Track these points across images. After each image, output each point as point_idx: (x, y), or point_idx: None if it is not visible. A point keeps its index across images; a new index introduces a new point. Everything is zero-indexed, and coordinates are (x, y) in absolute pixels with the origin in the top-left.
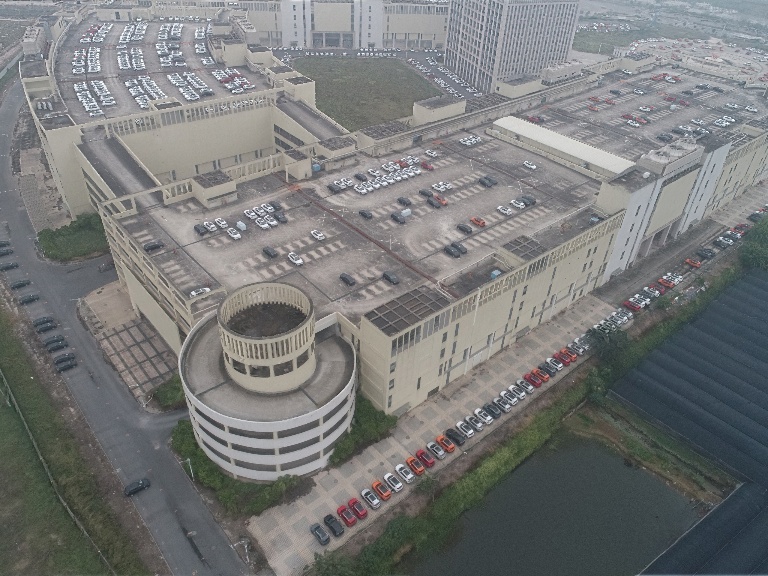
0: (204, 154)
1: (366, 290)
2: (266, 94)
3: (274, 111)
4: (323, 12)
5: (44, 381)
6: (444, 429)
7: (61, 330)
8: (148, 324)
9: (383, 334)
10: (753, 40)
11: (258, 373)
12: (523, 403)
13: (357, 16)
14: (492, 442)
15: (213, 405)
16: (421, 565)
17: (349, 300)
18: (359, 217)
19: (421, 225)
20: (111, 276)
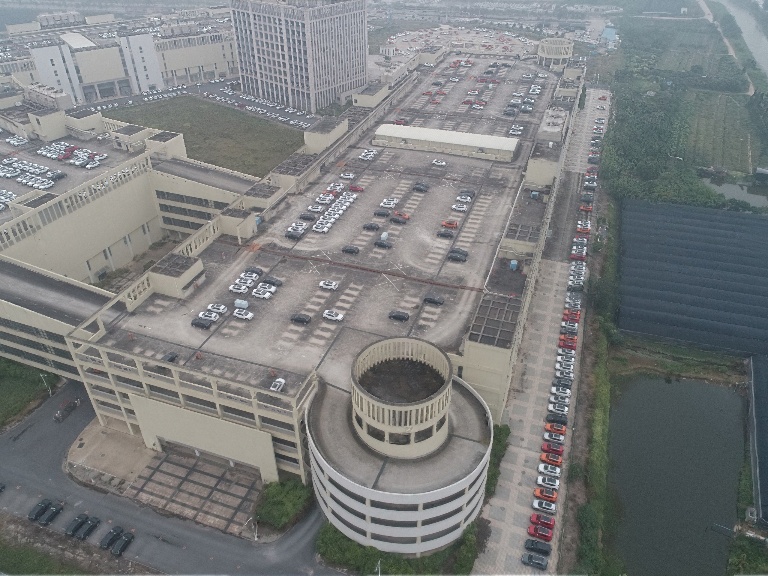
0: (92, 245)
1: (423, 319)
2: (140, 159)
3: (154, 176)
4: (88, 62)
5: (109, 575)
6: (542, 418)
7: (72, 508)
8: (177, 453)
9: (501, 349)
10: (473, 21)
11: (414, 438)
12: (576, 367)
13: (128, 59)
14: (584, 410)
15: (396, 490)
16: (617, 540)
17: (418, 334)
18: (345, 255)
19: (406, 244)
20: (78, 421)
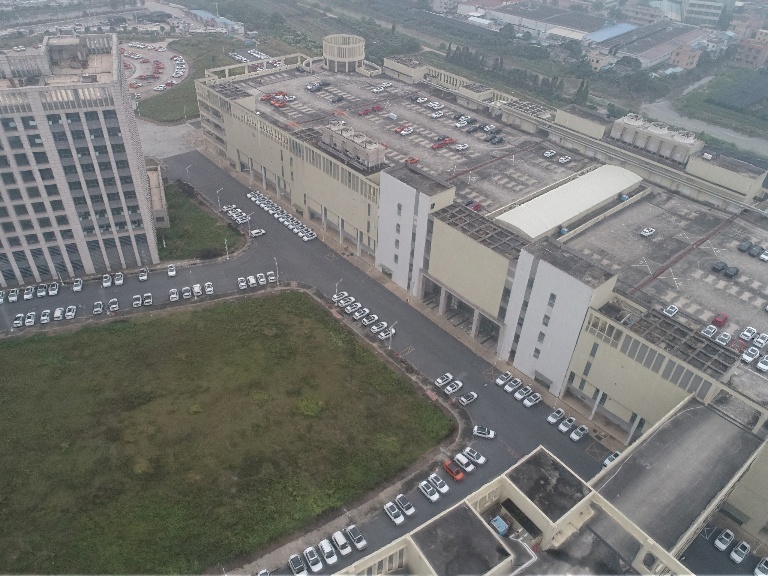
0: None
1: None
2: (675, 569)
3: None
4: None
5: None
6: None
7: None
8: None
9: None
10: (14, 35)
11: None
12: None
13: None
14: None
15: None
16: None
17: None
18: None
19: None
20: None
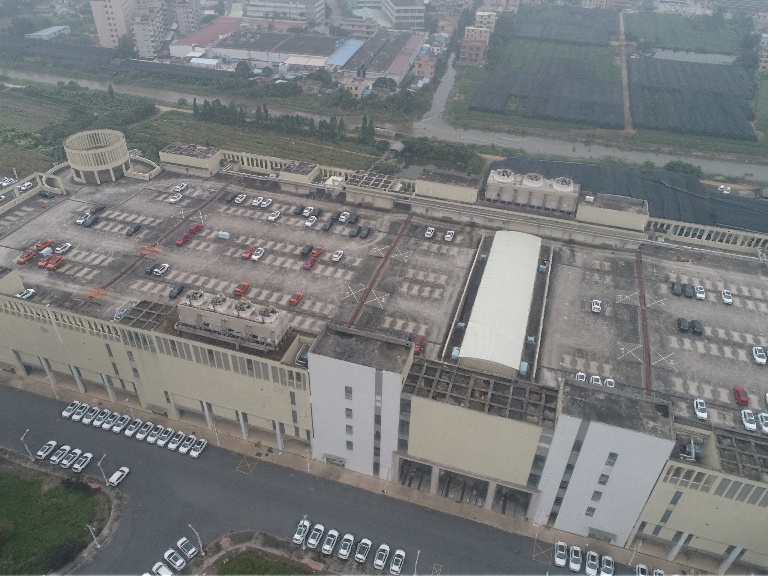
0: None
1: None
2: None
3: None
4: None
5: None
6: None
7: None
8: None
9: None
10: None
11: None
12: None
13: None
14: None
15: None
16: None
17: None
18: None
19: None
20: None
